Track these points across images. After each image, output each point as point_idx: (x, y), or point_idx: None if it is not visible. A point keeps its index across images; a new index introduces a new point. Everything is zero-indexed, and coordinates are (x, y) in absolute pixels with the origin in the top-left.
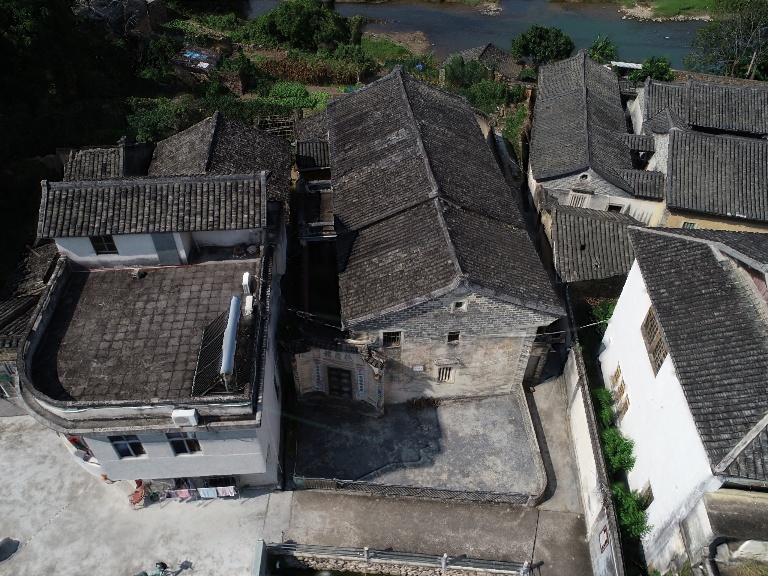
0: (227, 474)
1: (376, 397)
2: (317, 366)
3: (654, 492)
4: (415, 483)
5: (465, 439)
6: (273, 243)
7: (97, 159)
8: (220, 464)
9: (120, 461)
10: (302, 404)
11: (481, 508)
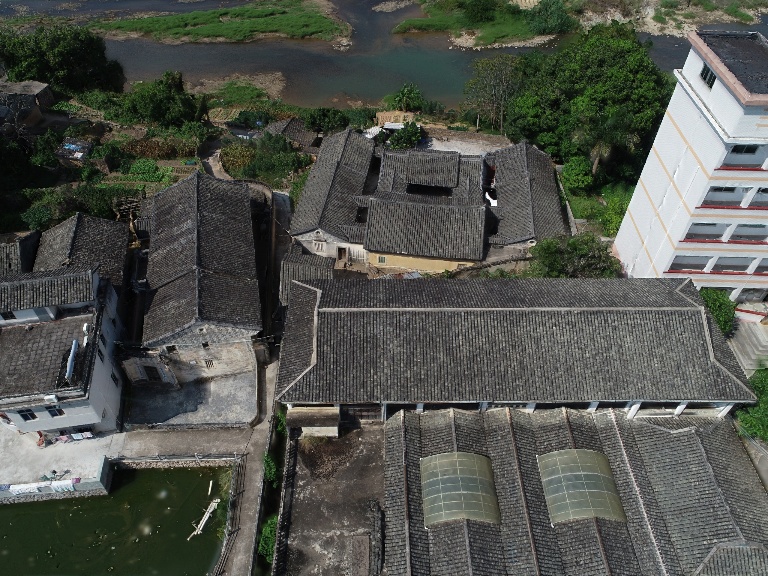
0: (81, 424)
1: (172, 380)
2: (137, 366)
3: None
4: (192, 422)
5: (223, 397)
6: (103, 304)
7: (3, 251)
8: (76, 420)
9: (25, 422)
10: (135, 387)
11: (224, 431)
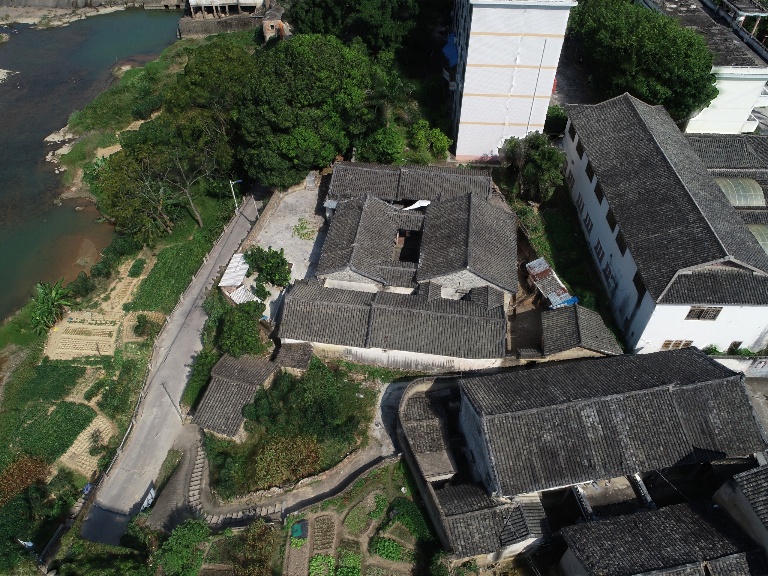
0: None
1: None
2: None
3: (742, 340)
4: None
5: None
6: None
7: None
8: None
9: None
10: None
11: None
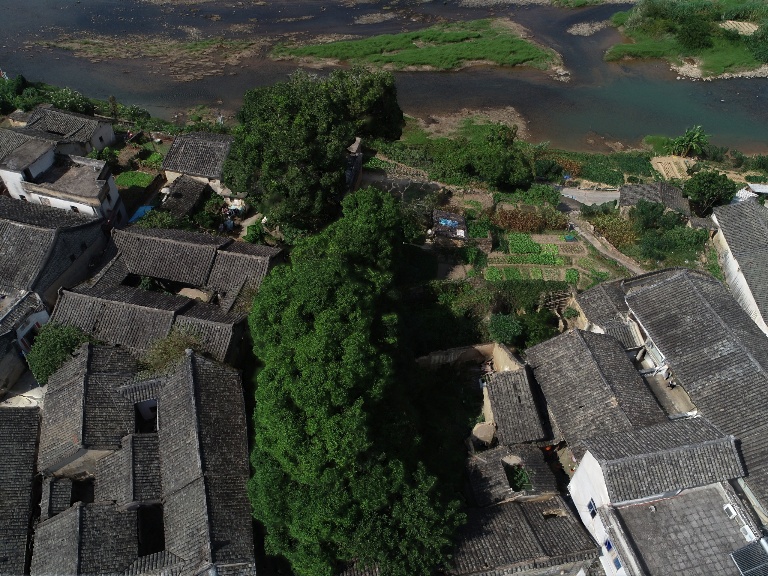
0: None
1: None
2: None
3: None
4: None
5: None
6: None
7: (508, 380)
8: None
9: None
10: None
11: None
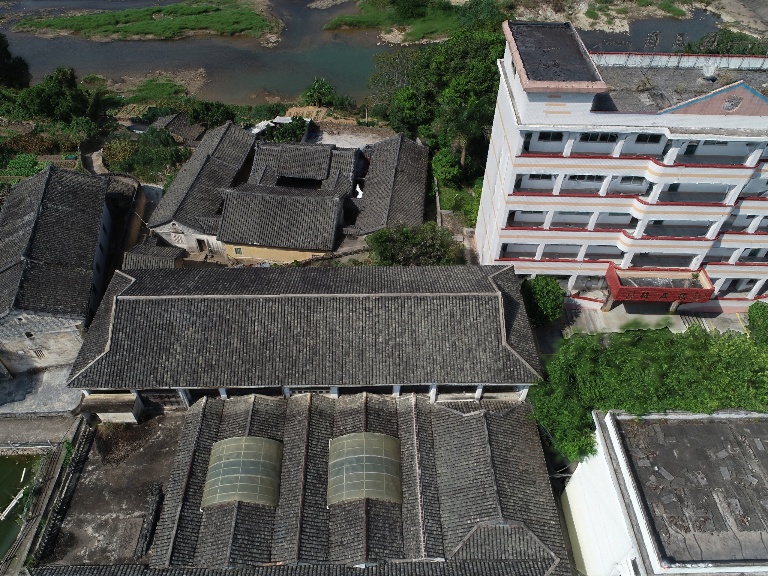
0: None
1: (1, 369)
2: None
3: None
4: None
5: (53, 387)
6: None
7: None
8: None
9: None
10: None
11: (46, 420)
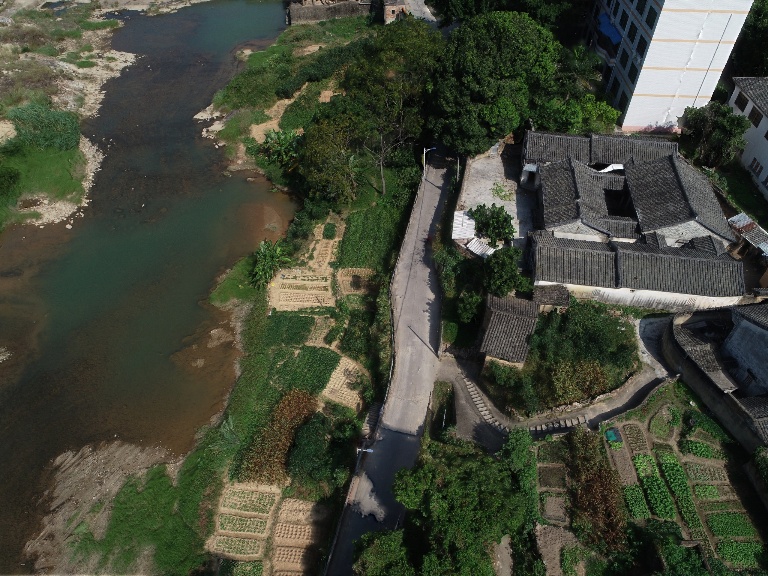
0: None
1: None
2: None
3: None
4: None
5: None
6: None
7: None
8: None
9: None
10: None
11: None
